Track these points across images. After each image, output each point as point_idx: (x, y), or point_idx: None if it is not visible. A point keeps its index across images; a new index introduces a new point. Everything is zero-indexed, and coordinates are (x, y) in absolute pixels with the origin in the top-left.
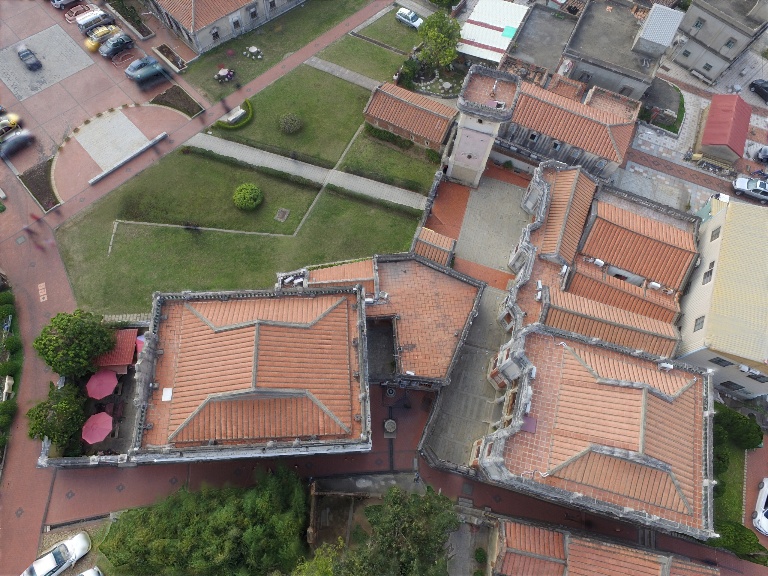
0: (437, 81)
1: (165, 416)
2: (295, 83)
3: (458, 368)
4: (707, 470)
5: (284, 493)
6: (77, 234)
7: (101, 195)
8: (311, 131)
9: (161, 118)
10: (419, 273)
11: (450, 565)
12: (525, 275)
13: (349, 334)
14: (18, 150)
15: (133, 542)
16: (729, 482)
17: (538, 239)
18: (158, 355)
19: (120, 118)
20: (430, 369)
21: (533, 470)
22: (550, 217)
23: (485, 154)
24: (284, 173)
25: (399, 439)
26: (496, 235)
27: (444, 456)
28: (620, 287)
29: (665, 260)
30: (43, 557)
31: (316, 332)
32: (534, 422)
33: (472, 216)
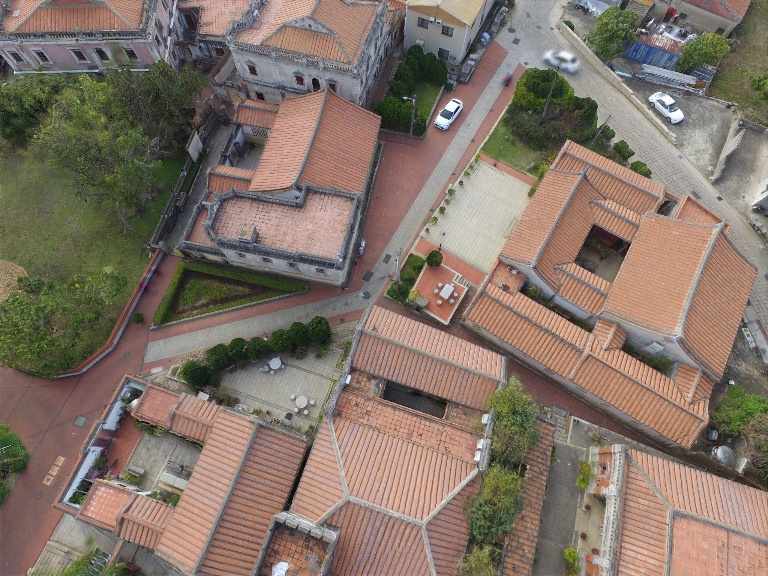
0: None
1: (13, 24)
2: None
3: None
4: None
5: None
6: None
7: None
8: None
9: None
10: None
11: (218, 144)
12: None
13: None
14: None
15: None
16: (425, 103)
17: None
18: None
19: None
20: None
21: None
22: None
23: None
24: None
25: None
26: None
27: (231, 97)
28: None
29: None
30: None
31: None
32: (260, 23)
33: None
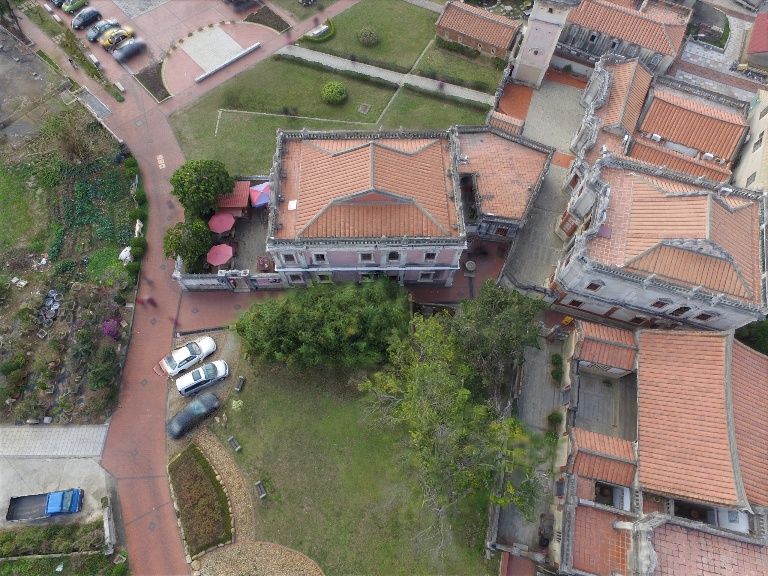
0: (499, 6)
1: (292, 220)
2: (370, 7)
3: (528, 225)
4: (765, 266)
5: (388, 294)
6: (187, 119)
7: (205, 91)
8: (387, 44)
9: (254, 33)
10: (494, 142)
11: (529, 368)
12: (591, 141)
13: (443, 167)
14: (132, 56)
15: (267, 316)
16: None
17: (601, 116)
18: (282, 178)
19: (218, 32)
20: (507, 214)
21: (610, 264)
22: (611, 99)
23: (551, 48)
24: (365, 75)
25: (478, 278)
26: (558, 125)
27: None
28: (676, 155)
29: (717, 134)
30: (179, 349)
31: (417, 160)
32: (609, 230)
33: (535, 111)
